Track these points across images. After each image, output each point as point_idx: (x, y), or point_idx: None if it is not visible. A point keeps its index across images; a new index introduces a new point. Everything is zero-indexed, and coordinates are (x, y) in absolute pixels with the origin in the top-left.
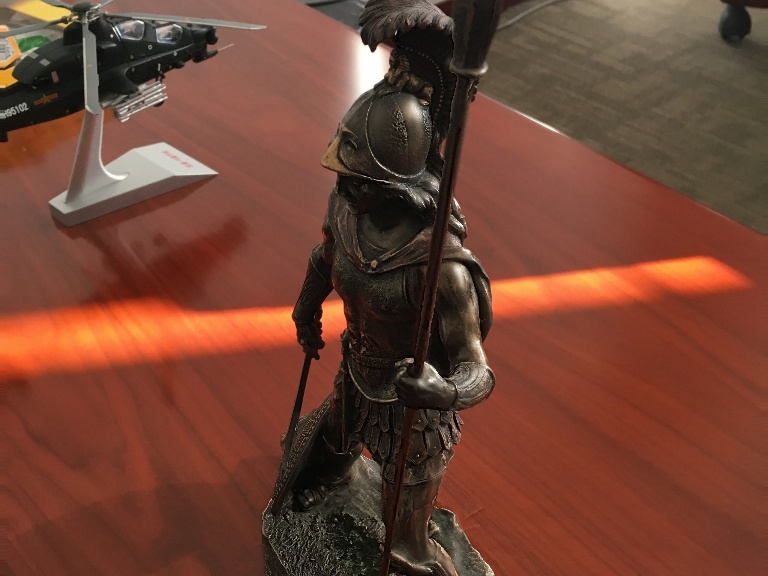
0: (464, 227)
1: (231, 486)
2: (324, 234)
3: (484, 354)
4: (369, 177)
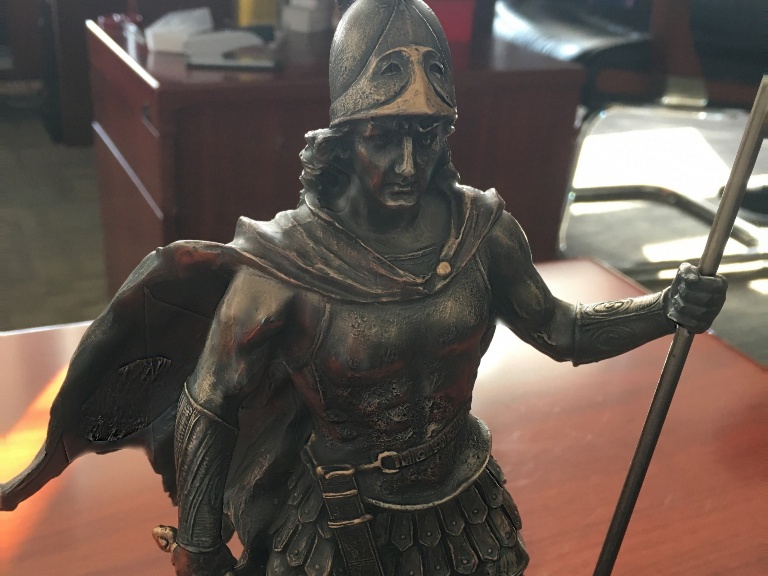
0: None
1: None
2: (268, 327)
3: None
4: None
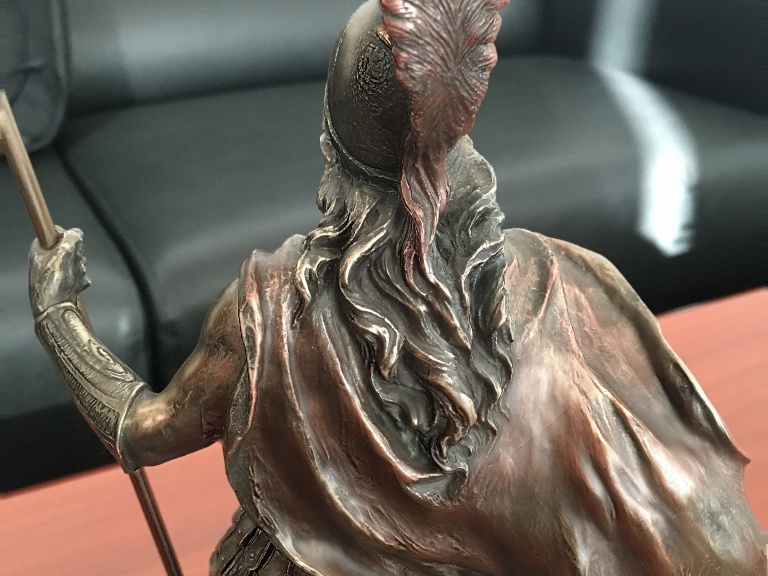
0: (371, 340)
1: None
2: None
3: (152, 418)
4: None
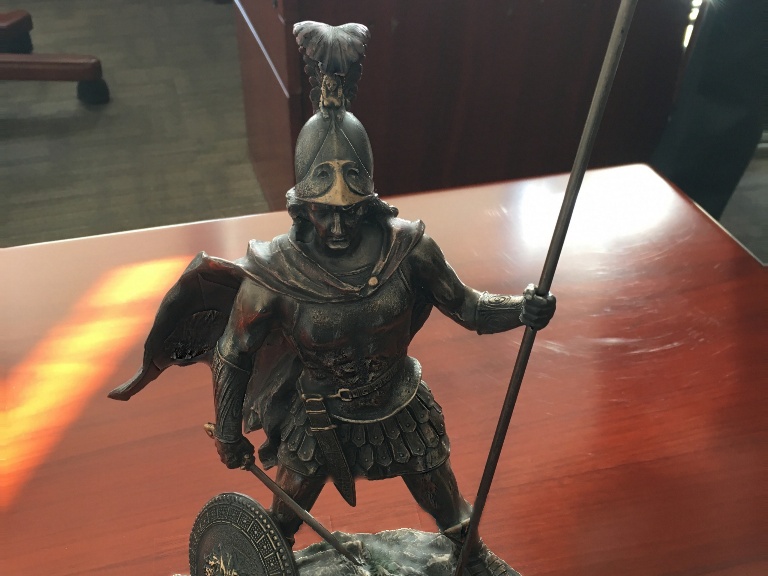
0: None
1: None
2: (262, 315)
3: None
4: (370, 195)
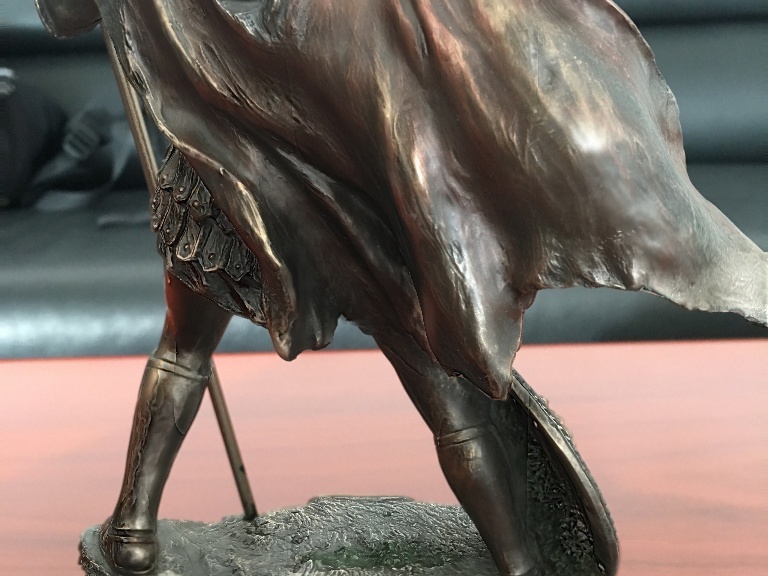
0: None
1: (658, 559)
2: None
3: None
4: None
